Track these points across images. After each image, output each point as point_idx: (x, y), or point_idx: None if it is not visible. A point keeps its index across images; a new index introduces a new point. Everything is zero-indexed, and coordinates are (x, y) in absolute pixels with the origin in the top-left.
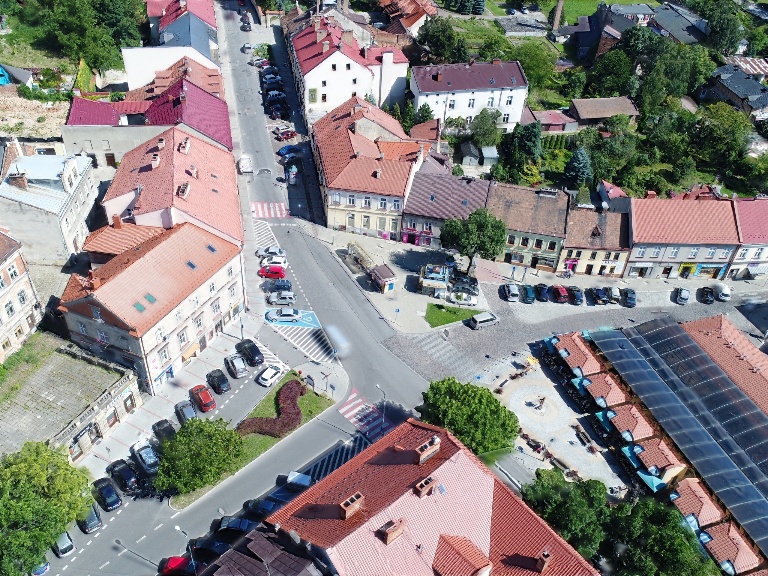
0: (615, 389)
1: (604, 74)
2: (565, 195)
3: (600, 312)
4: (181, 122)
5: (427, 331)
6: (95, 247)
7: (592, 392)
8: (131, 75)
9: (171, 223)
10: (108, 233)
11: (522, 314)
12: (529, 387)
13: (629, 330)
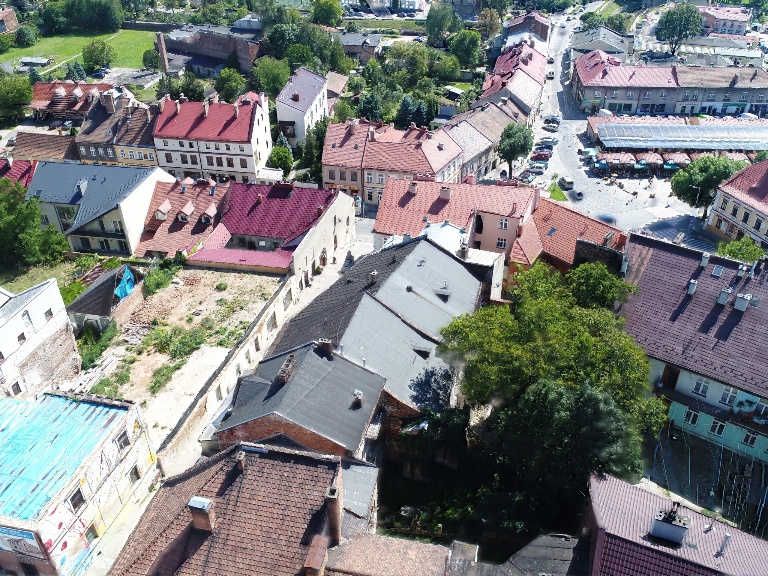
0: (654, 153)
1: (300, 64)
2: (491, 104)
3: (560, 152)
4: (339, 190)
5: (572, 203)
6: (533, 257)
7: (653, 161)
8: (130, 232)
9: (537, 204)
10: (523, 243)
11: (558, 173)
12: (630, 186)
13: (603, 138)
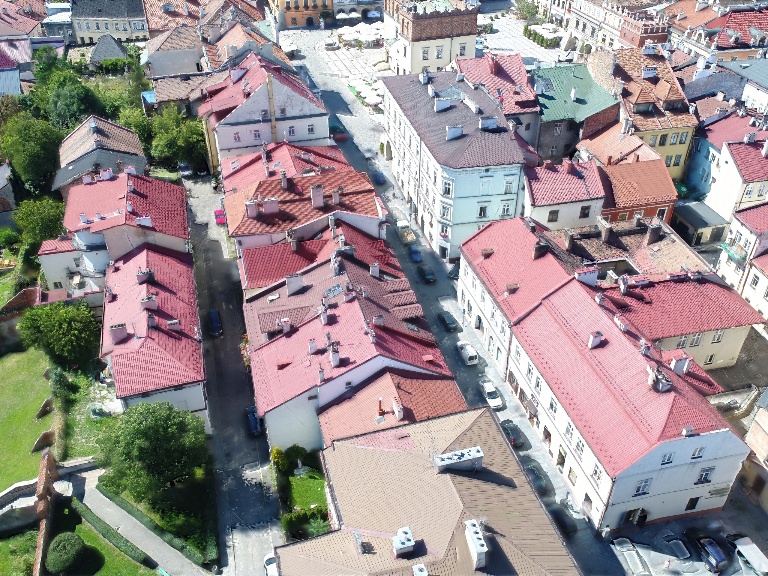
0: None
1: None
2: None
3: None
4: None
5: None
6: None
7: None
8: None
9: None
10: None
11: None
12: None
13: None
